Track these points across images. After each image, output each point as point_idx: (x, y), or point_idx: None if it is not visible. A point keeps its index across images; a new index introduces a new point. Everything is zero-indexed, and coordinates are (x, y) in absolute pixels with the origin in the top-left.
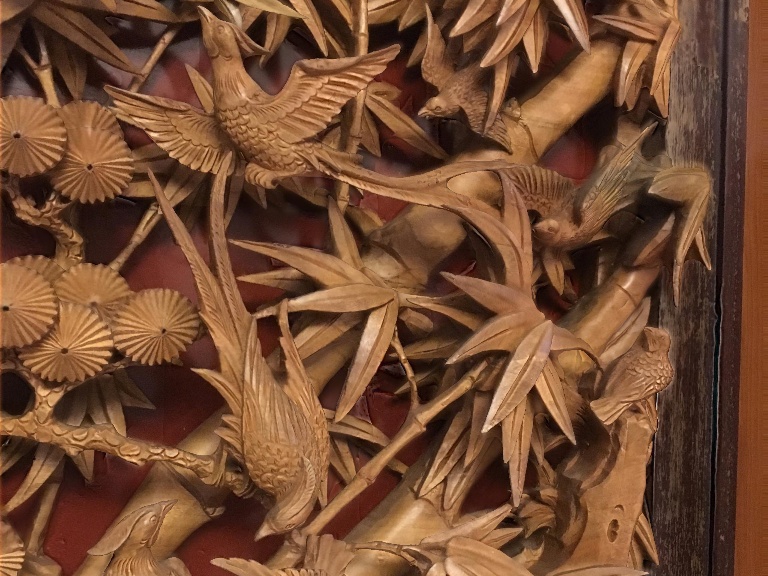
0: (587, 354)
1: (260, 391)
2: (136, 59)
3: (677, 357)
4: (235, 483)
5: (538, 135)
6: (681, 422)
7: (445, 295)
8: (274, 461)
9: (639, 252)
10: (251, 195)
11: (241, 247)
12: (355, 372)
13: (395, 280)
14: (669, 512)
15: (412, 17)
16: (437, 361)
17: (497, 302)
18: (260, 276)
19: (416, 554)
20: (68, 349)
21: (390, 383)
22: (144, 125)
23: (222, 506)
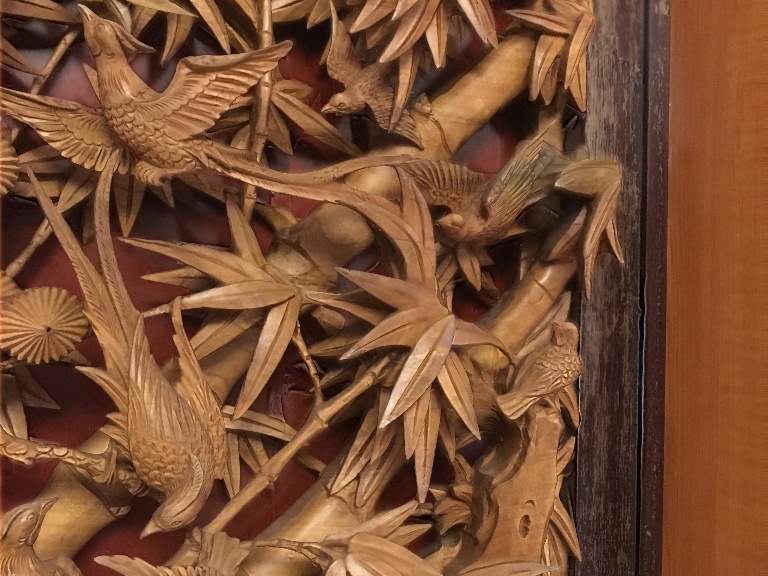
0: None
1: (145, 388)
2: (36, 60)
3: (600, 352)
4: (129, 481)
5: (450, 130)
6: (605, 417)
7: None
8: (160, 458)
9: (553, 246)
10: (157, 194)
11: (132, 245)
12: (253, 369)
13: (303, 277)
14: (593, 508)
15: (320, 14)
16: None
17: (396, 297)
18: (164, 275)
19: (317, 551)
20: None
21: (305, 381)
22: (34, 125)
23: None
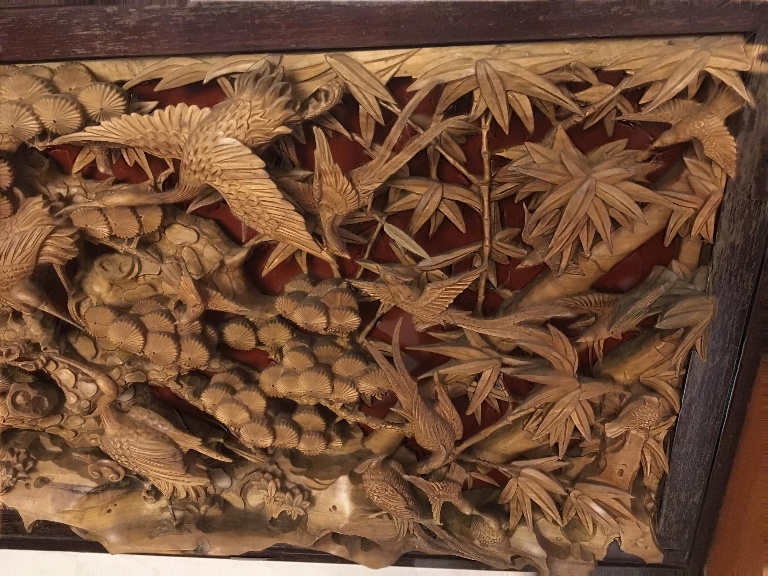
0: None
1: (419, 419)
2: (368, 234)
3: (702, 375)
4: None
5: (604, 263)
6: (700, 407)
7: (530, 359)
8: (427, 444)
9: (664, 336)
10: None
11: None
12: (475, 397)
13: (508, 340)
14: (684, 449)
15: (523, 195)
16: None
17: (546, 382)
18: (437, 334)
19: None
20: (339, 398)
21: None
22: (366, 291)
23: None
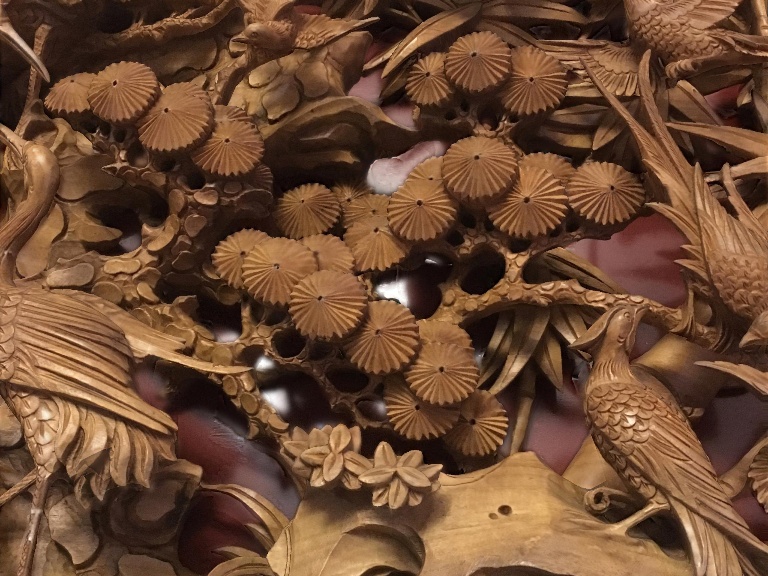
0: None
1: (715, 215)
2: None
3: None
4: (708, 337)
5: None
6: None
7: None
8: (744, 274)
9: None
10: None
11: (673, 128)
12: None
13: None
14: None
15: None
16: None
17: None
18: None
19: None
20: (529, 198)
21: None
22: (571, 66)
23: (700, 408)
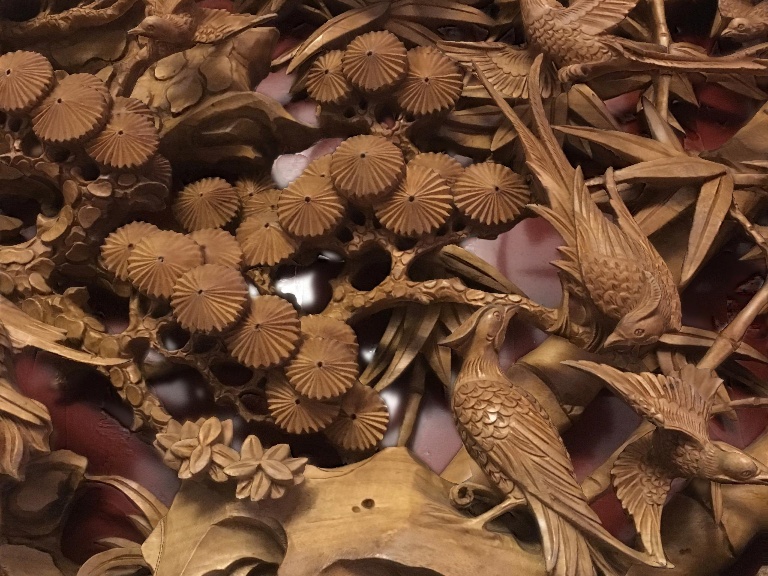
0: None
1: (591, 218)
2: None
3: None
4: (583, 336)
5: None
6: None
7: None
8: (613, 275)
9: None
10: (575, 146)
11: (562, 132)
12: (695, 233)
13: None
14: None
15: None
16: None
17: None
18: (591, 196)
19: None
20: (414, 197)
21: None
22: (470, 67)
23: None
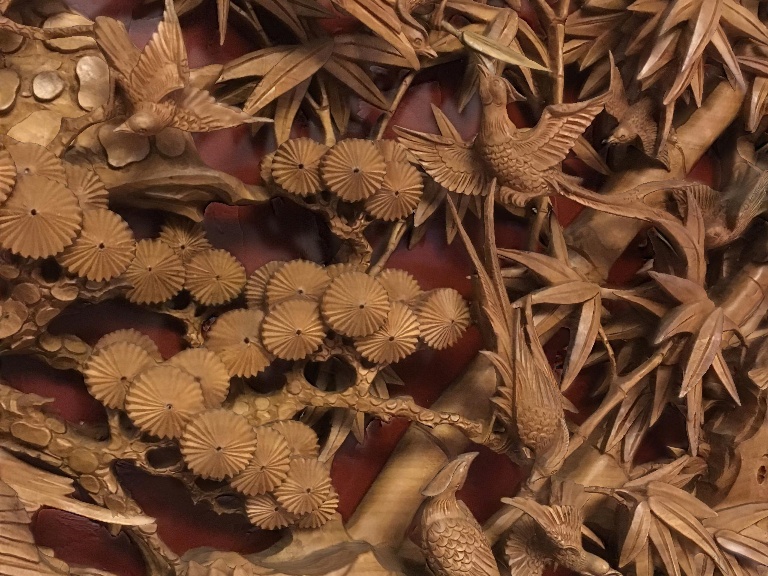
0: (736, 334)
1: (528, 367)
2: (388, 99)
3: None
4: (494, 441)
5: (689, 155)
6: None
7: (632, 288)
8: (540, 422)
9: None
10: (470, 208)
11: (497, 254)
12: (576, 352)
13: None
14: None
15: (590, 59)
16: (613, 342)
17: (684, 294)
18: None
19: (624, 495)
20: (394, 337)
21: None
22: (419, 157)
23: None
